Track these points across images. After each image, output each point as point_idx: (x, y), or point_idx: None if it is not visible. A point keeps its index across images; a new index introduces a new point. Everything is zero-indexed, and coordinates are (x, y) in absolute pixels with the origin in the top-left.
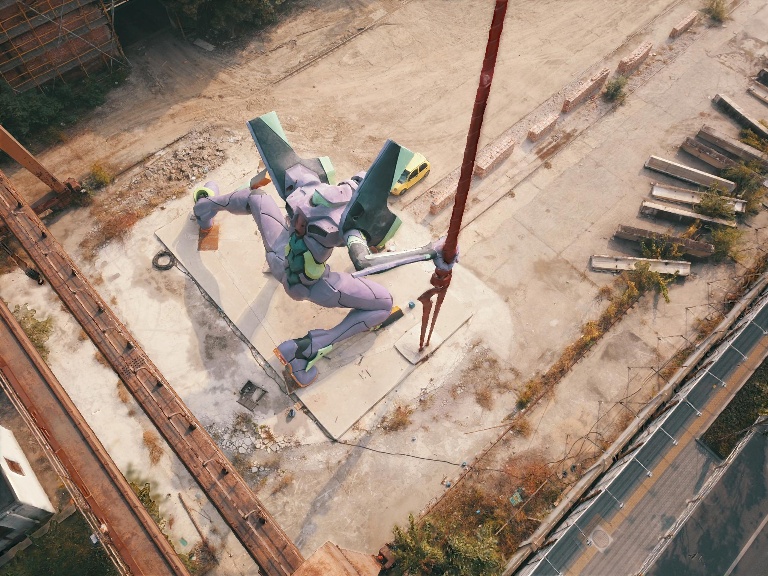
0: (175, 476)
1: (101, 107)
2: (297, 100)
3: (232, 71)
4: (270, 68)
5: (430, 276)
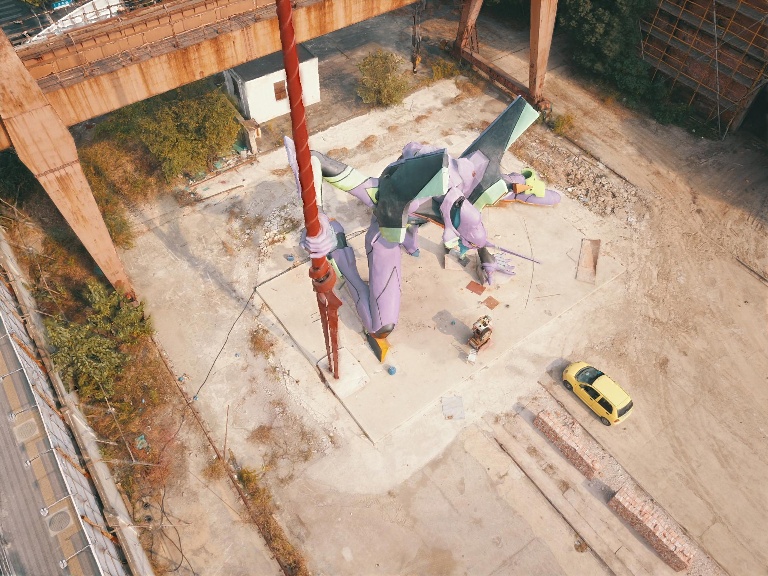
0: (258, 184)
1: (656, 123)
2: (715, 283)
3: (747, 221)
4: (767, 258)
5: (433, 400)
